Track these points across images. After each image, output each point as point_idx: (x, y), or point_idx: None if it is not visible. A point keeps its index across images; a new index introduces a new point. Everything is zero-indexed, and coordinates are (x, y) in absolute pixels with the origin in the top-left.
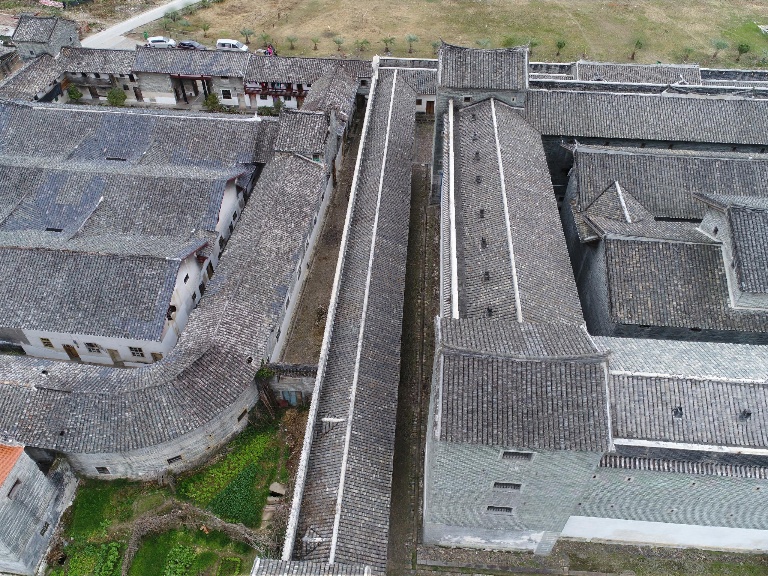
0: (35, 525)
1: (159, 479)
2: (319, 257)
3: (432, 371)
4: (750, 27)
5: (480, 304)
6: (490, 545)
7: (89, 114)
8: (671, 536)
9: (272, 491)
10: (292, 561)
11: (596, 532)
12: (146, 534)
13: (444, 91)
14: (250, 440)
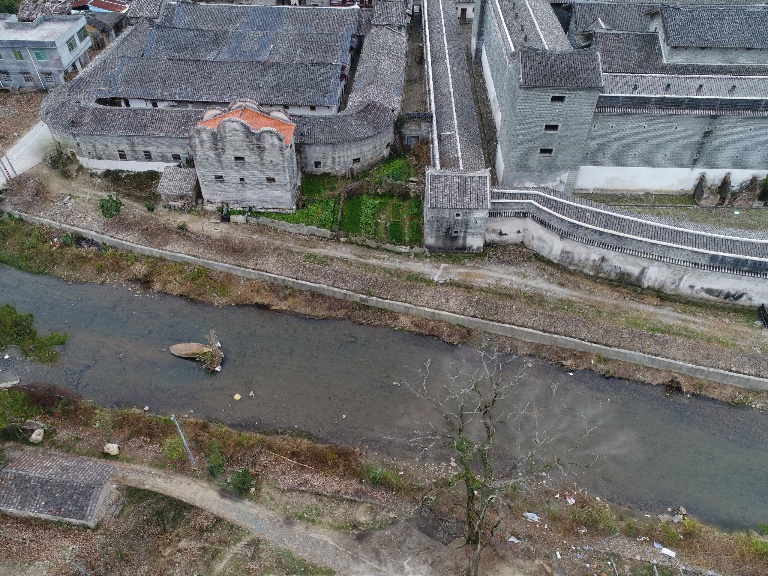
0: (293, 179)
1: (347, 174)
2: (407, 90)
3: (492, 135)
4: None
5: None
6: None
7: (240, 7)
8: (636, 181)
9: (411, 180)
10: None
11: (595, 182)
12: (349, 191)
13: None
14: (392, 162)
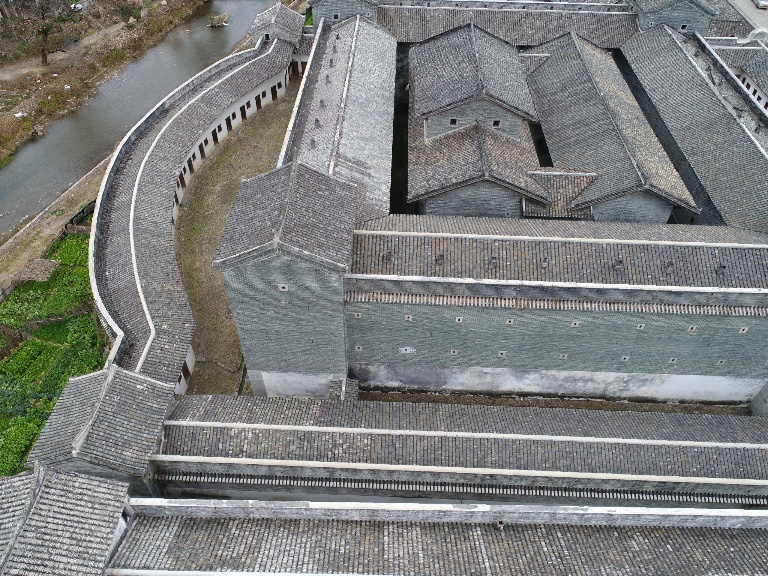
0: None
1: None
2: None
3: None
4: None
5: None
6: None
7: None
8: None
9: None
10: None
11: None
12: None
13: None
14: None
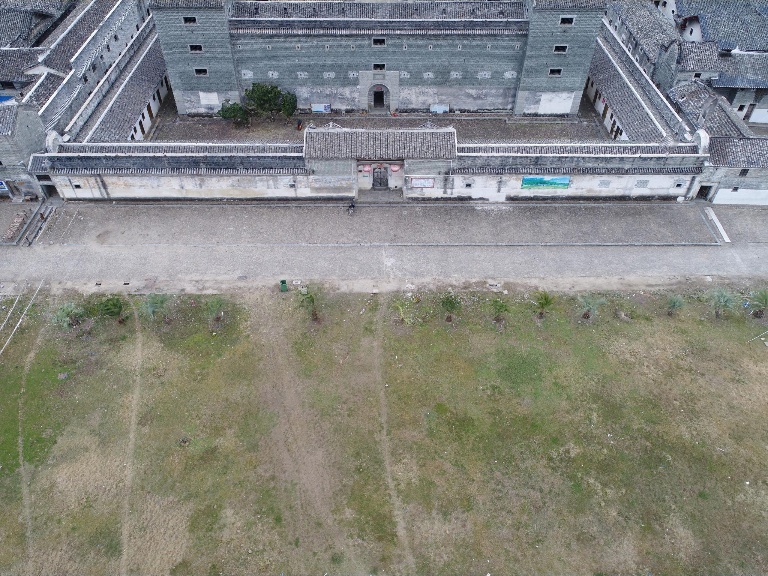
0: None
1: None
2: None
3: None
4: None
5: None
6: None
7: None
8: None
9: None
10: None
11: None
12: None
13: None
14: None
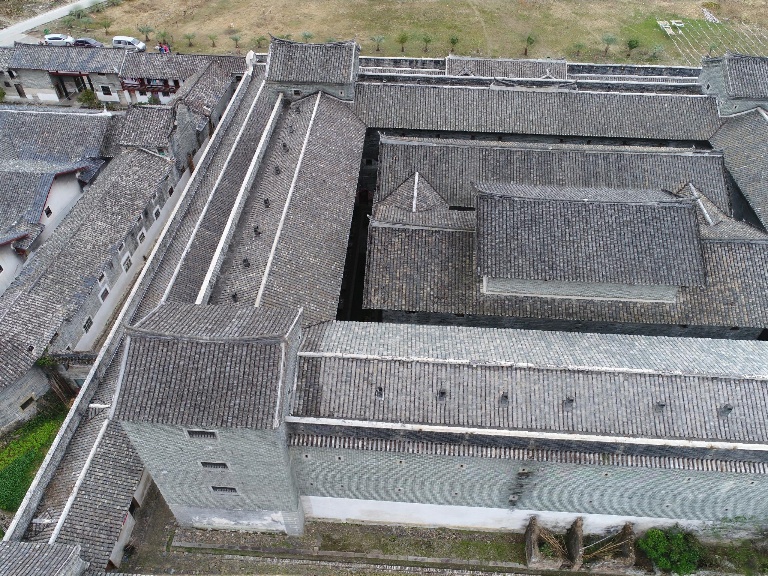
0: None
1: None
2: None
3: None
4: (651, 23)
5: (233, 291)
6: (242, 526)
7: None
8: (416, 516)
9: None
10: (5, 541)
11: (345, 513)
12: None
13: (273, 85)
14: (38, 428)
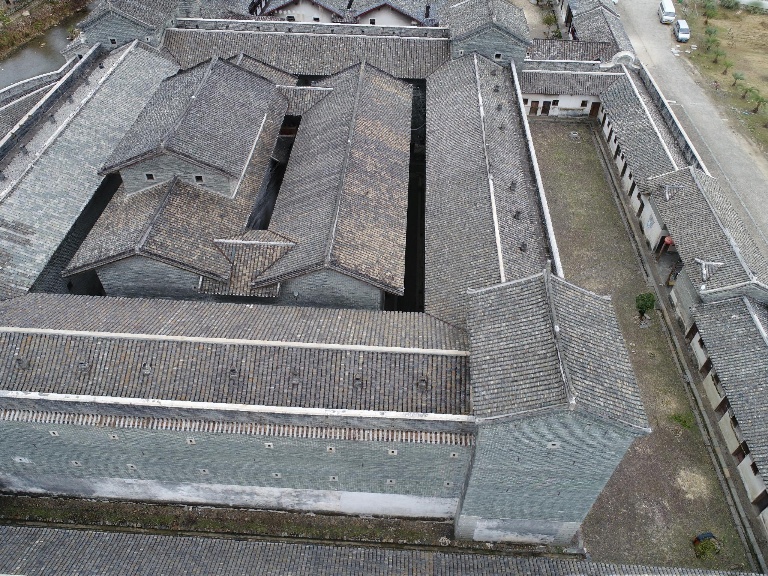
0: None
1: None
2: None
3: None
4: None
5: None
6: None
7: None
8: None
9: None
10: None
11: None
12: None
13: None
14: None
